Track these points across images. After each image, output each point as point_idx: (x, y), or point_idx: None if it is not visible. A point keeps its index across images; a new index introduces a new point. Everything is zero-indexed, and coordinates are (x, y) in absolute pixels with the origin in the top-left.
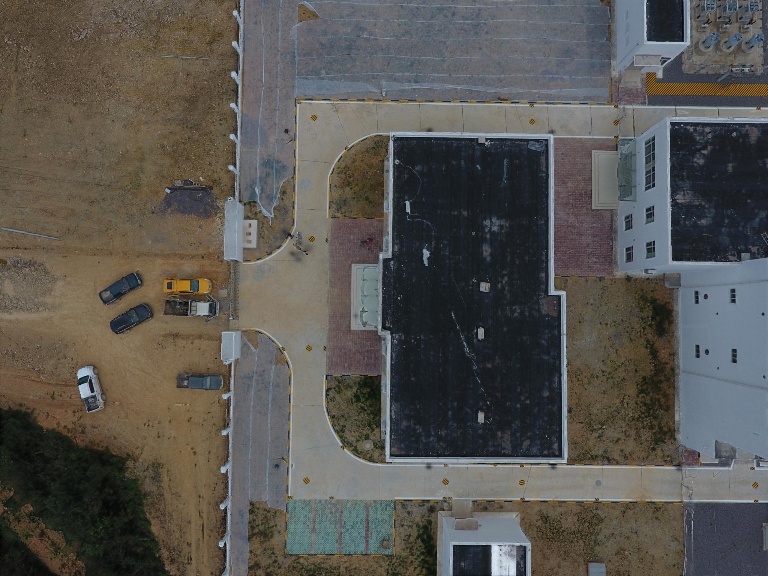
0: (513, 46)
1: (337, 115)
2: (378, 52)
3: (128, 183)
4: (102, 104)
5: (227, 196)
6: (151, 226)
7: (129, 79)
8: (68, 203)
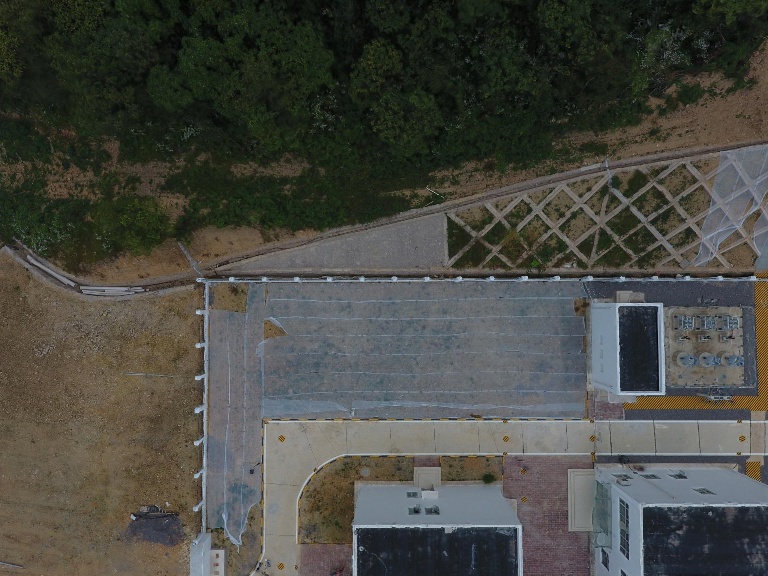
0: (485, 360)
1: (305, 435)
2: (347, 369)
3: (93, 508)
4: (65, 425)
5: (194, 522)
6: (117, 554)
7: (92, 398)
8: (32, 528)
